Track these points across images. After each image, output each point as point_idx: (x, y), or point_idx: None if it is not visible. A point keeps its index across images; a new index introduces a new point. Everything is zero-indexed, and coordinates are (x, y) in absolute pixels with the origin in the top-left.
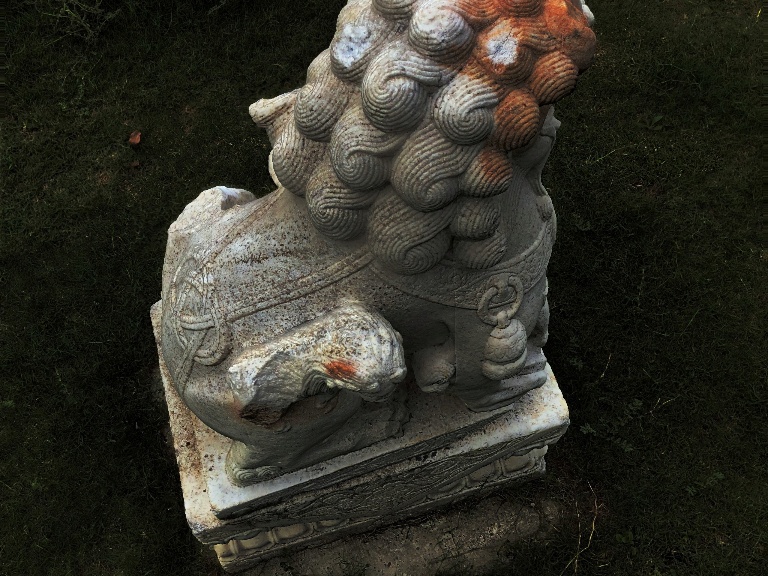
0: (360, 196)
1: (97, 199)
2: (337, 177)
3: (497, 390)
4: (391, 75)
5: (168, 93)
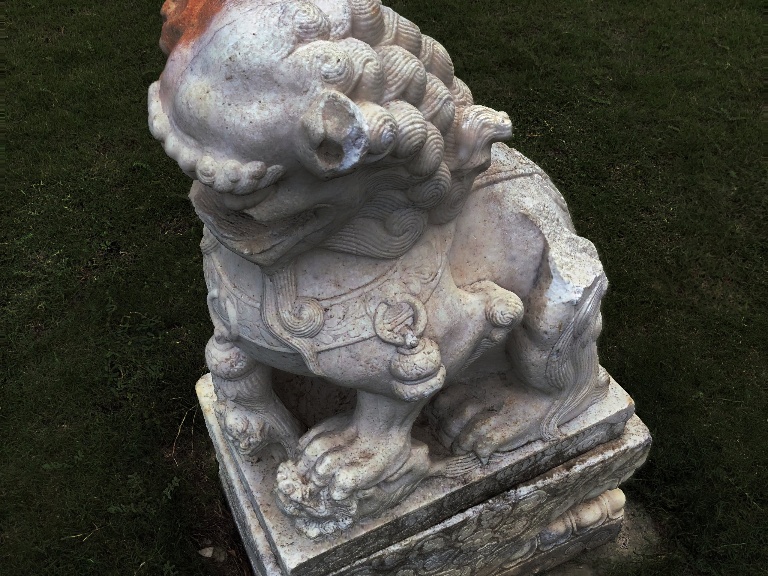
0: None
1: None
2: None
3: None
4: None
5: None
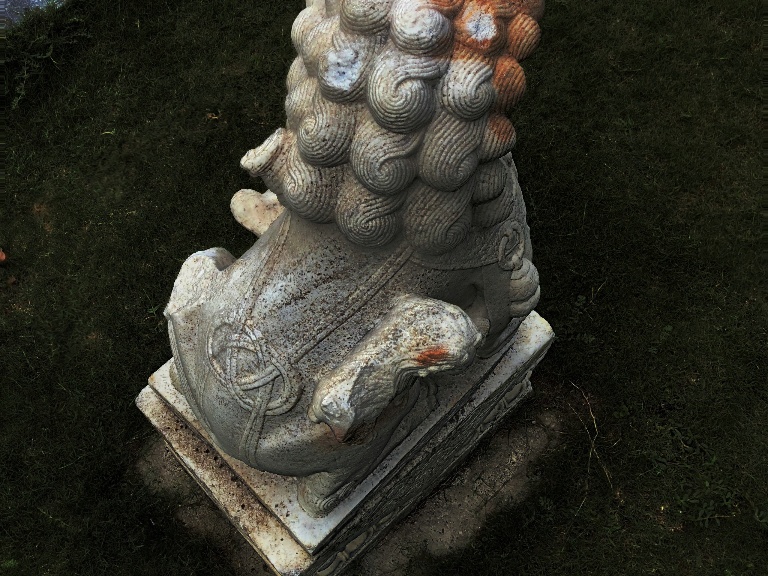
0: (394, 199)
1: None
2: (368, 191)
3: None
4: (399, 82)
5: (8, 199)
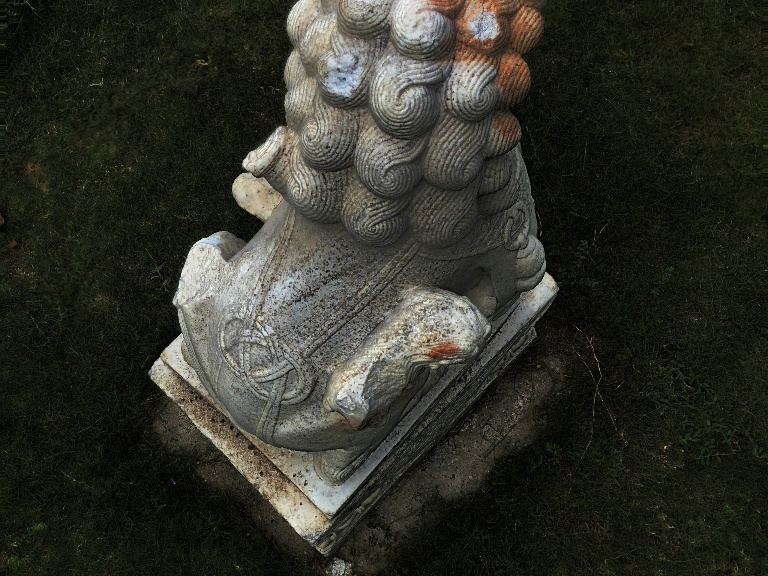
0: (400, 201)
1: None
2: (374, 195)
3: None
4: (401, 90)
5: (1, 160)
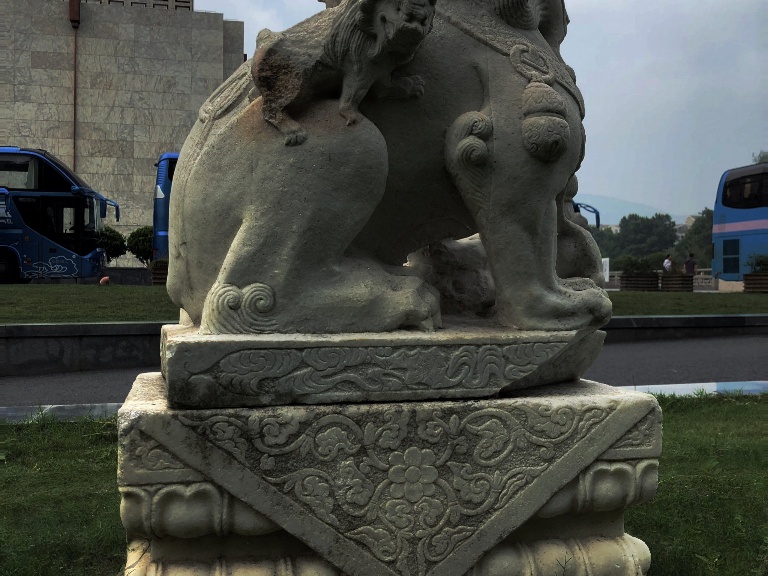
0: None
1: None
2: None
3: (550, 283)
4: None
5: None
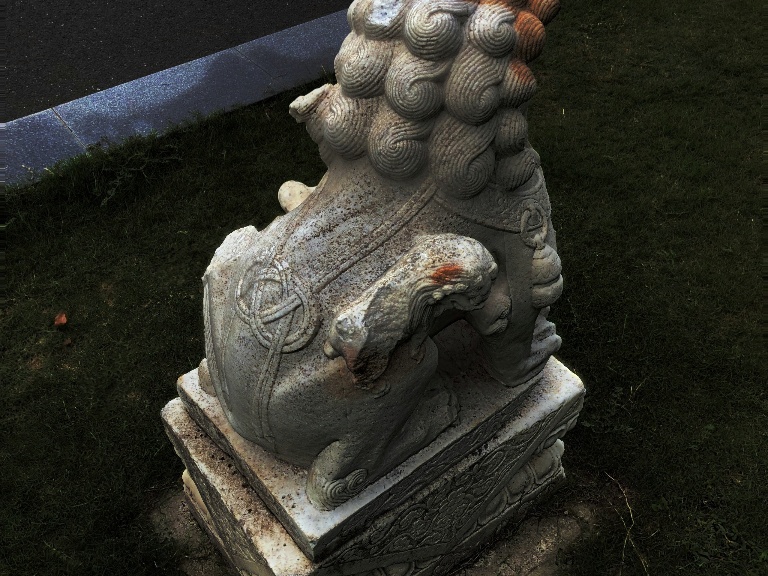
0: (421, 126)
1: (37, 381)
2: (398, 115)
3: (529, 354)
4: (431, 12)
5: (81, 278)
